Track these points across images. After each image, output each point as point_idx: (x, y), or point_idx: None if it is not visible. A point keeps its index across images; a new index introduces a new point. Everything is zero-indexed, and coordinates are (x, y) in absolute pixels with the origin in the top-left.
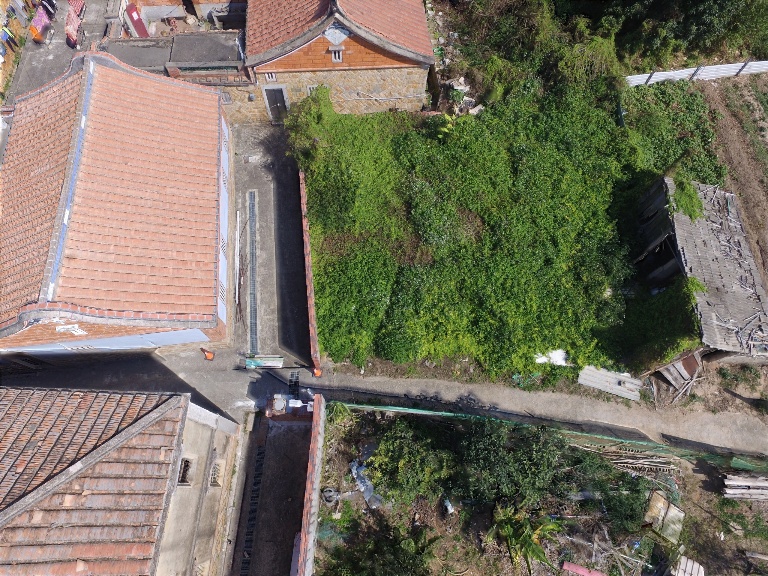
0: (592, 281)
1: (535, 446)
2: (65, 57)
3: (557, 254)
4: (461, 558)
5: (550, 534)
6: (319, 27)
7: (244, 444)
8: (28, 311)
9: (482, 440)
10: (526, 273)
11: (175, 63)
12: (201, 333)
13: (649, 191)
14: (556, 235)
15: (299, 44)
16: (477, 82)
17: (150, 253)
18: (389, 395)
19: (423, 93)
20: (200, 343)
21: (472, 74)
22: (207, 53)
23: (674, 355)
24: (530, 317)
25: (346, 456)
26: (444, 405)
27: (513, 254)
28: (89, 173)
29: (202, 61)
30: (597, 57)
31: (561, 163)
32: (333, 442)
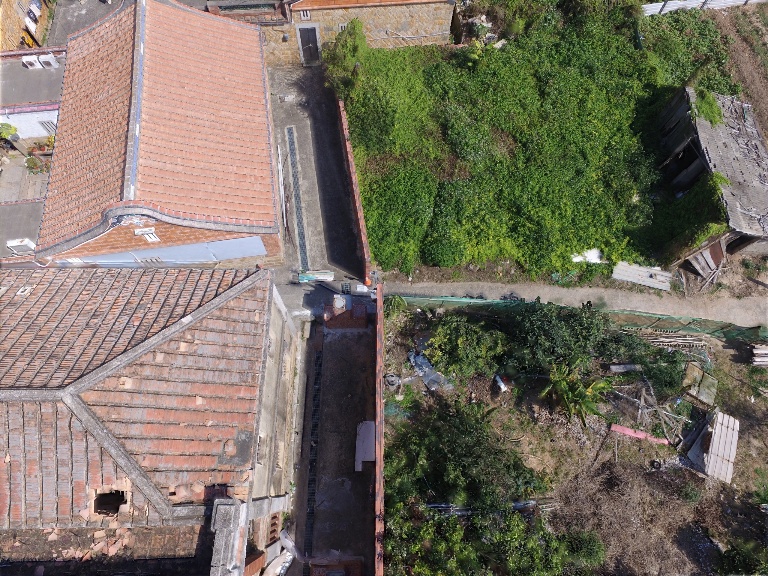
0: (621, 187)
1: (584, 315)
2: (98, 11)
3: (587, 164)
4: (517, 427)
5: (600, 394)
6: None
7: (302, 350)
8: (115, 208)
9: (535, 313)
10: (560, 181)
11: (216, 2)
12: (261, 244)
13: (670, 103)
14: (585, 148)
15: None
16: (499, 18)
17: (213, 166)
18: None
19: (448, 30)
20: (257, 258)
21: (494, 11)
22: None
23: (704, 237)
24: (565, 221)
25: (404, 346)
26: None
27: (547, 165)
28: (152, 94)
29: (240, 1)
30: None
31: (585, 84)
32: (391, 336)
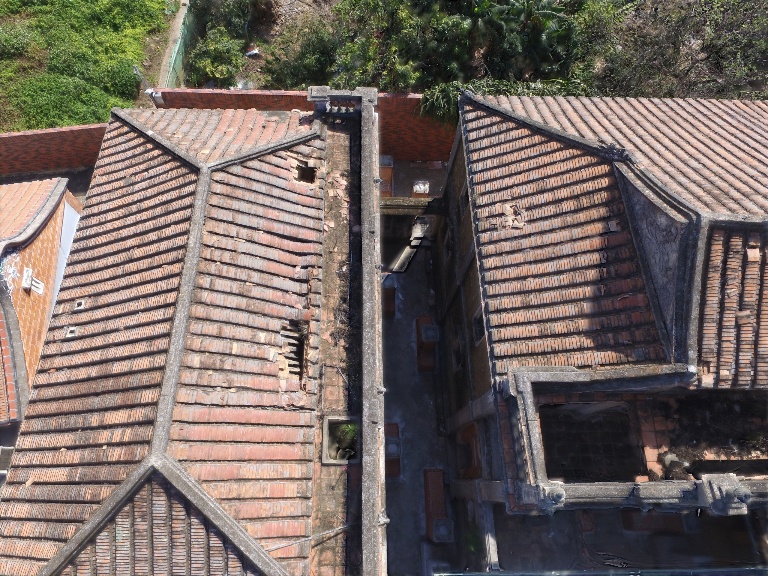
0: None
1: None
2: None
3: None
4: None
5: None
6: None
7: None
8: None
9: None
10: None
11: None
12: (75, 214)
13: None
14: None
15: None
16: None
17: None
18: None
19: None
20: None
21: None
22: None
23: None
24: None
25: None
26: None
27: None
28: None
29: None
30: None
31: None
32: None
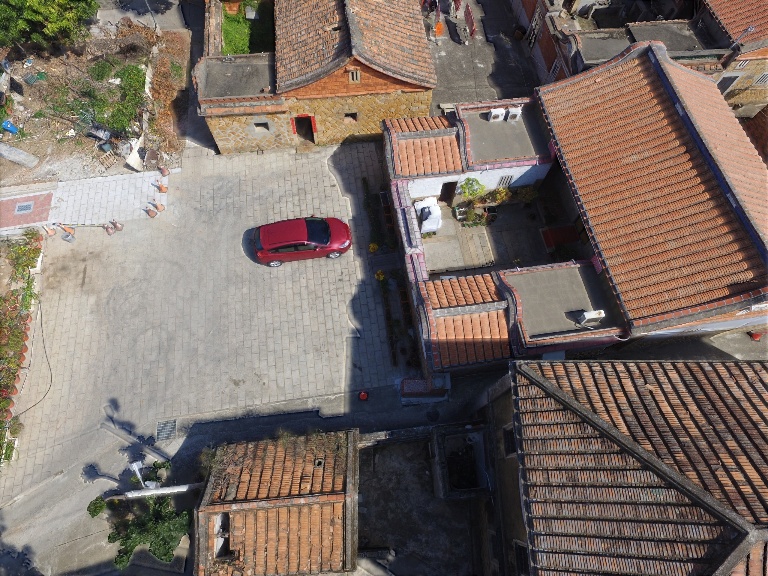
0: None
1: None
2: (457, 53)
3: None
4: None
5: None
6: None
7: None
8: None
9: None
10: None
11: (669, 52)
12: None
13: None
14: None
15: None
16: None
17: None
18: None
19: None
20: None
21: None
22: (671, 43)
23: None
24: None
25: None
26: None
27: None
28: None
29: None
30: None
31: None
32: None
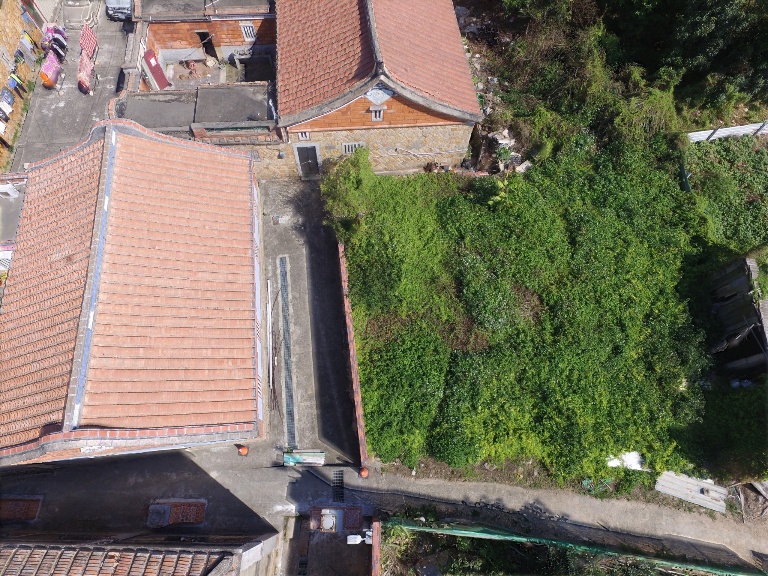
0: (666, 372)
1: None
2: (77, 104)
3: (626, 340)
4: None
5: None
6: (361, 89)
7: (284, 554)
8: (51, 442)
9: None
10: (594, 364)
11: (202, 124)
12: None
13: (725, 269)
14: (623, 318)
15: (338, 105)
16: (523, 136)
17: (183, 353)
18: (445, 501)
19: (465, 148)
20: (235, 441)
21: (518, 127)
22: (234, 109)
23: None
24: (600, 414)
25: None
26: (507, 515)
27: (578, 342)
28: (114, 263)
29: (230, 120)
30: (656, 112)
31: (624, 234)
32: (388, 564)
